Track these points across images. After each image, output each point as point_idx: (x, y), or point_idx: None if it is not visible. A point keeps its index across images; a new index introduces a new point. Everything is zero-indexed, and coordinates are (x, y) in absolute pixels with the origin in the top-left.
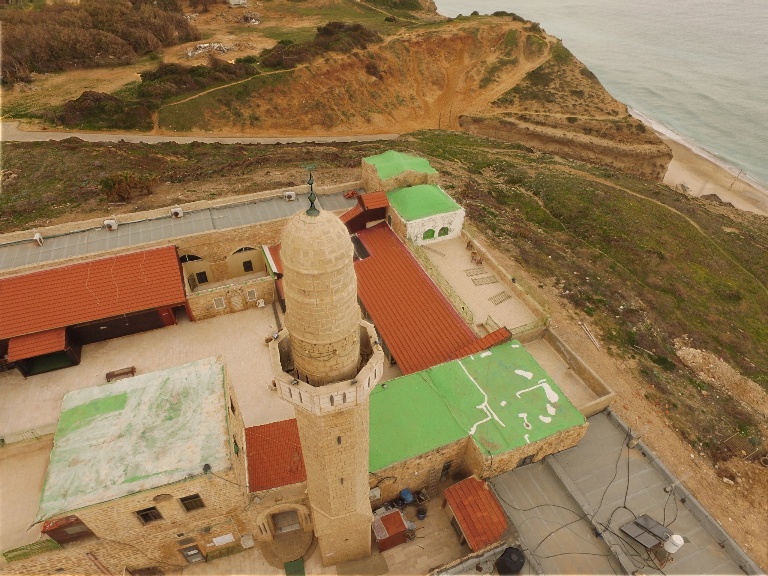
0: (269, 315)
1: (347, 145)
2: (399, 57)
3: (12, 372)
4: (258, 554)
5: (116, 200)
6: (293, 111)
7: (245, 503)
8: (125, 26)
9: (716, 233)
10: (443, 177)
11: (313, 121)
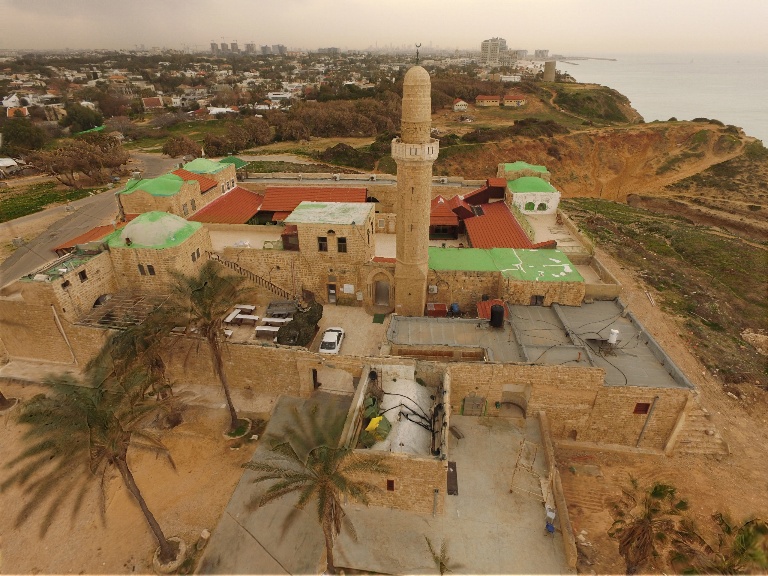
0: None
1: None
2: (581, 145)
3: None
4: (363, 309)
5: None
6: (476, 172)
7: None
8: (375, 113)
9: None
10: (579, 212)
11: None
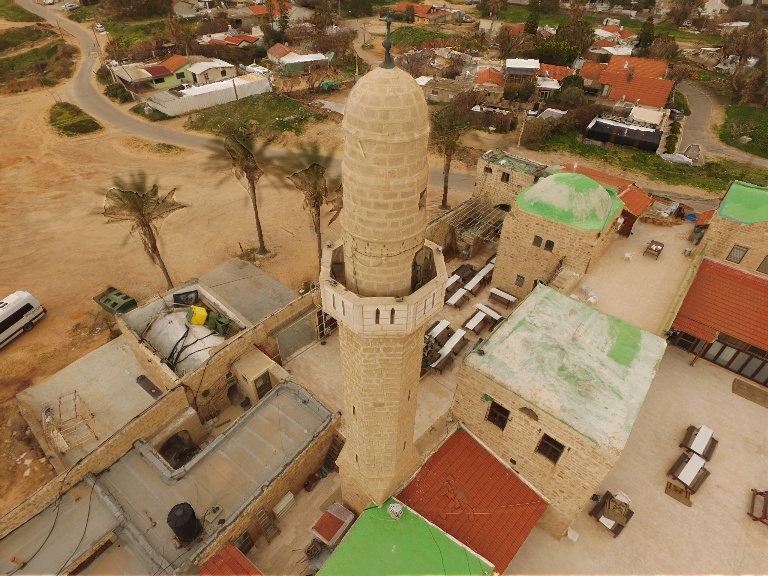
0: None
1: None
2: None
3: None
4: None
5: None
6: None
7: (454, 407)
8: None
9: None
10: None
11: None
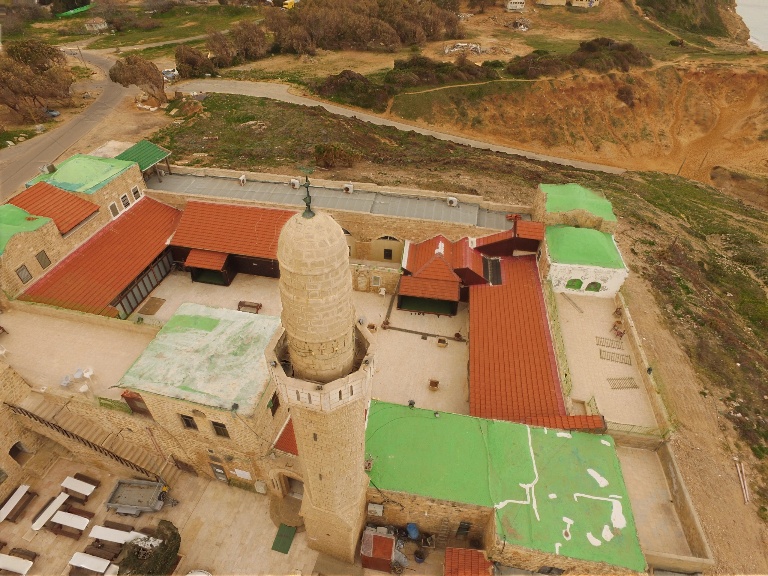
0: (384, 305)
1: (558, 168)
2: (664, 86)
3: (187, 274)
4: (267, 503)
5: (322, 165)
6: (518, 121)
7: (262, 453)
8: (402, 18)
9: None
10: (647, 229)
11: (535, 136)
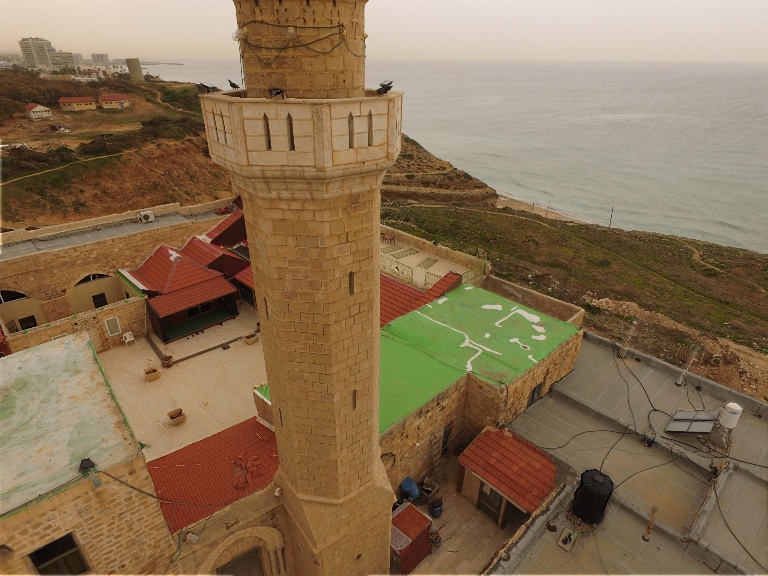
0: (144, 349)
1: None
2: None
3: None
4: None
5: None
6: (127, 194)
7: (171, 546)
8: None
9: (564, 227)
10: None
11: (153, 202)
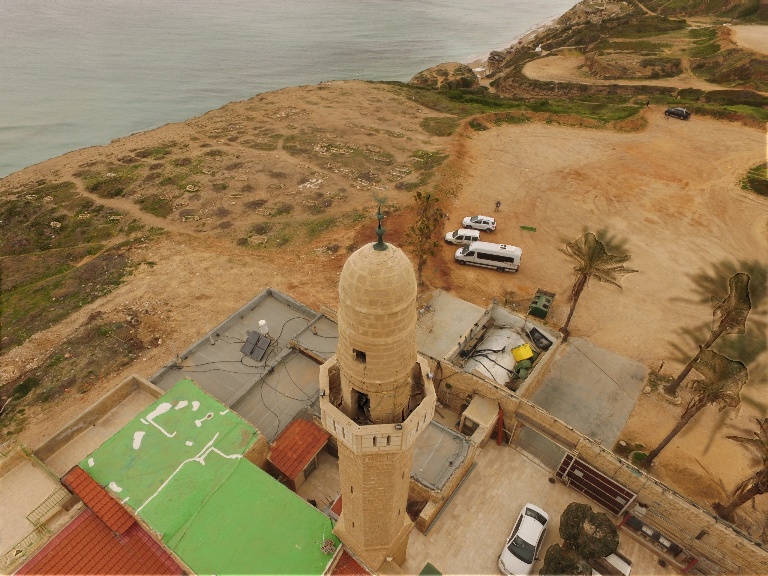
0: None
1: None
2: None
3: None
4: None
5: None
6: None
7: None
8: None
9: None
10: None
11: None
